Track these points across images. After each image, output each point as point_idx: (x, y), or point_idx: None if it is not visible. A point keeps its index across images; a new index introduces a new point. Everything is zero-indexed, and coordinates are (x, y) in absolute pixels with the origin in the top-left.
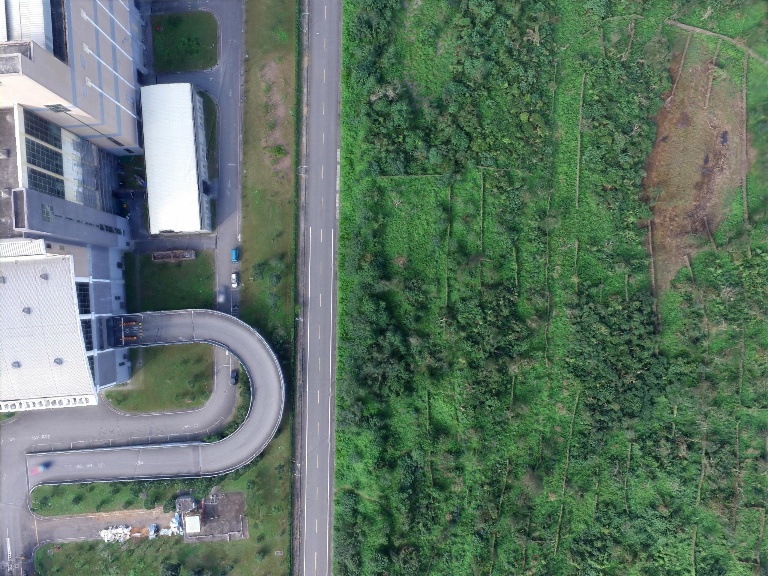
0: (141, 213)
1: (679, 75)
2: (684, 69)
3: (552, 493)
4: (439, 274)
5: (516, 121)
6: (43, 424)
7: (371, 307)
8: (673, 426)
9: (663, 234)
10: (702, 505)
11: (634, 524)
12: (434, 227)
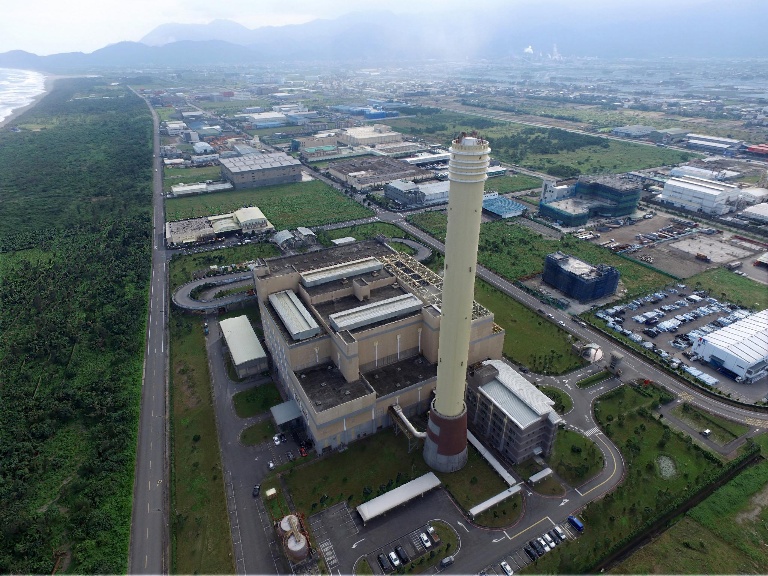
0: None
1: None
2: None
3: None
4: None
5: None
6: None
7: None
8: None
9: None
10: None
11: None
12: None
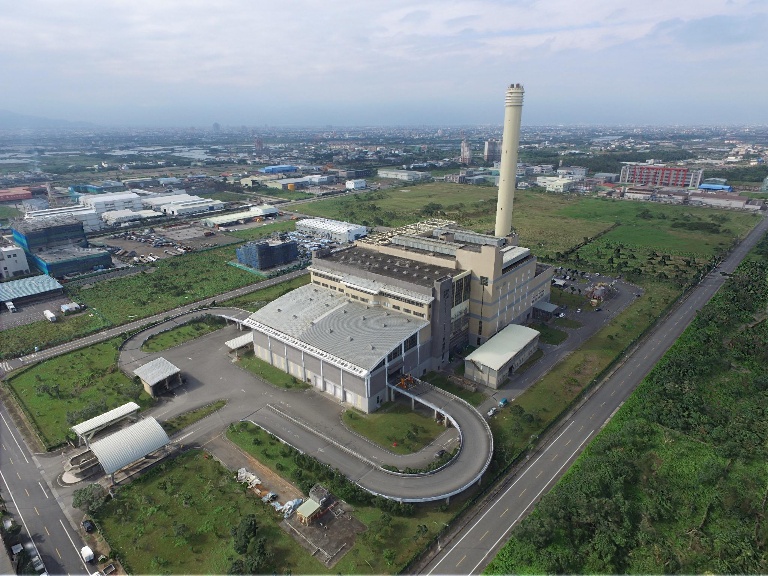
0: (459, 365)
1: None
2: None
3: None
4: (698, 504)
5: None
6: (295, 400)
7: (608, 471)
8: None
9: None
10: None
11: None
12: None
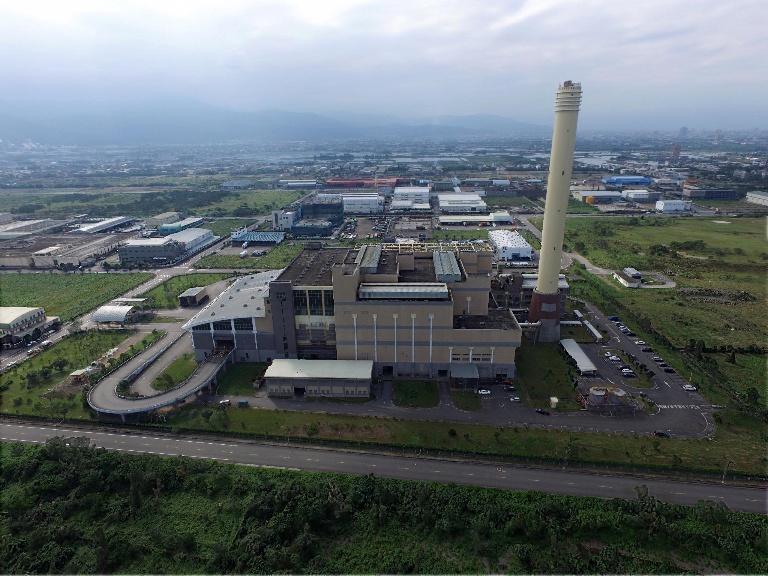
0: None
1: None
2: None
3: None
4: None
5: None
6: None
7: None
8: None
9: None
10: None
11: None
12: None
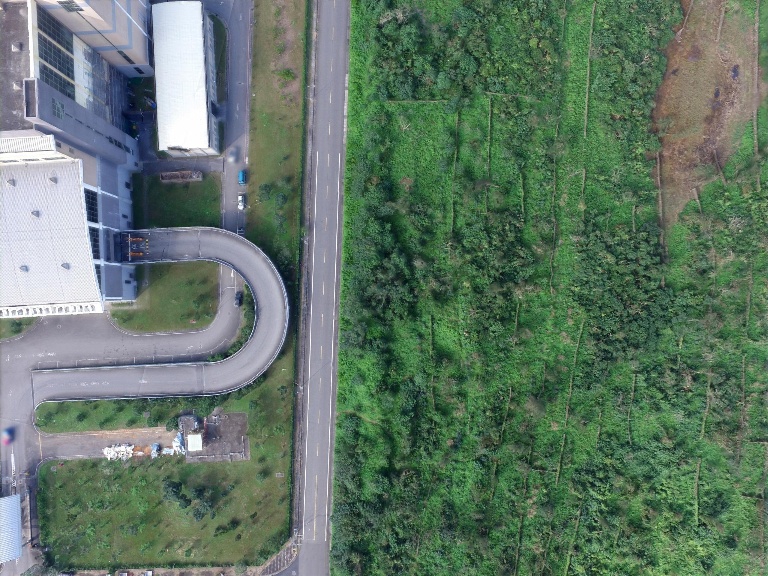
0: (150, 135)
1: (691, 7)
2: (696, 2)
3: (554, 422)
4: (445, 200)
5: (525, 46)
6: (49, 342)
7: (376, 228)
8: (678, 358)
9: (672, 167)
10: (706, 438)
11: (637, 456)
12: (441, 153)
